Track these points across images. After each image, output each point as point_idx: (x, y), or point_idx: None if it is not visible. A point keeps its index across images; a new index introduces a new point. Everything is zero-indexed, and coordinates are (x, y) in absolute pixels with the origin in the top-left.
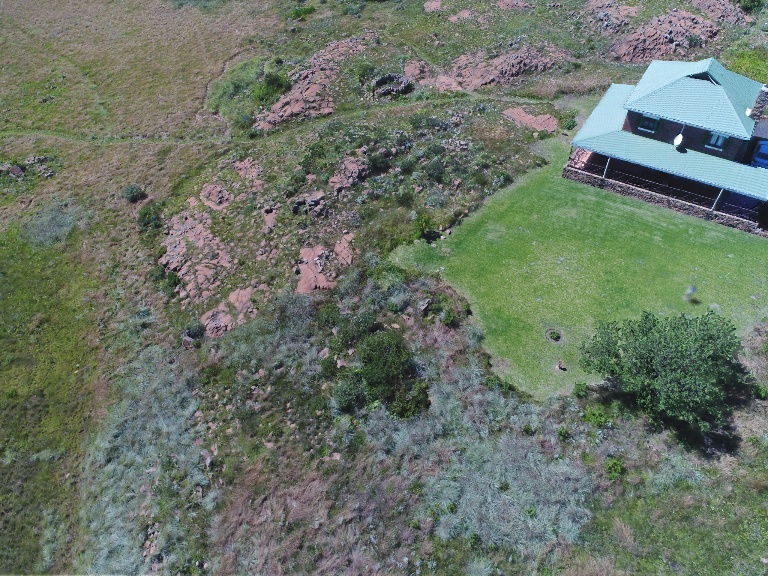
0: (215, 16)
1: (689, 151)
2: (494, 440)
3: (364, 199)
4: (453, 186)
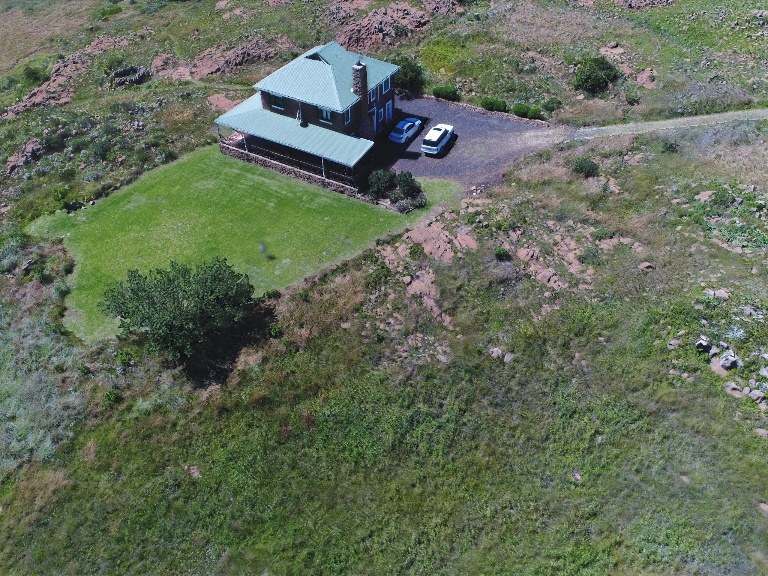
0: (33, 18)
1: (310, 125)
2: (26, 378)
3: (32, 176)
4: (117, 163)
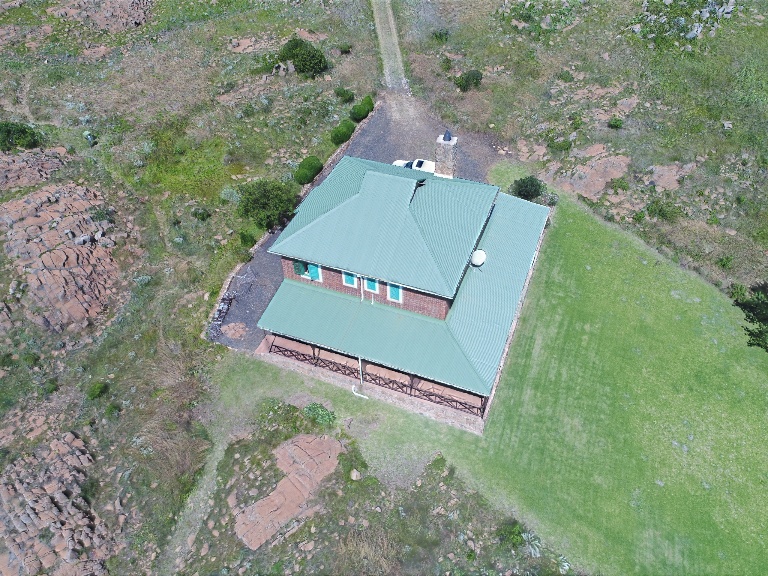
0: None
1: None
2: None
3: None
4: None
